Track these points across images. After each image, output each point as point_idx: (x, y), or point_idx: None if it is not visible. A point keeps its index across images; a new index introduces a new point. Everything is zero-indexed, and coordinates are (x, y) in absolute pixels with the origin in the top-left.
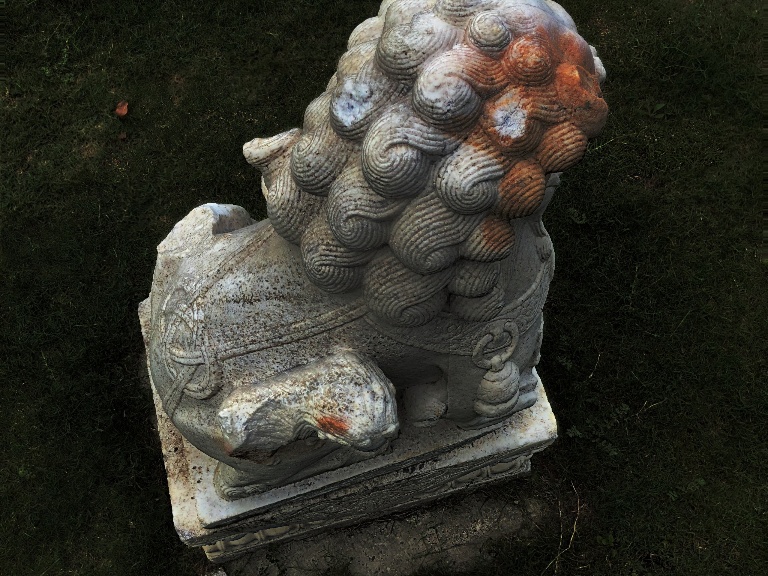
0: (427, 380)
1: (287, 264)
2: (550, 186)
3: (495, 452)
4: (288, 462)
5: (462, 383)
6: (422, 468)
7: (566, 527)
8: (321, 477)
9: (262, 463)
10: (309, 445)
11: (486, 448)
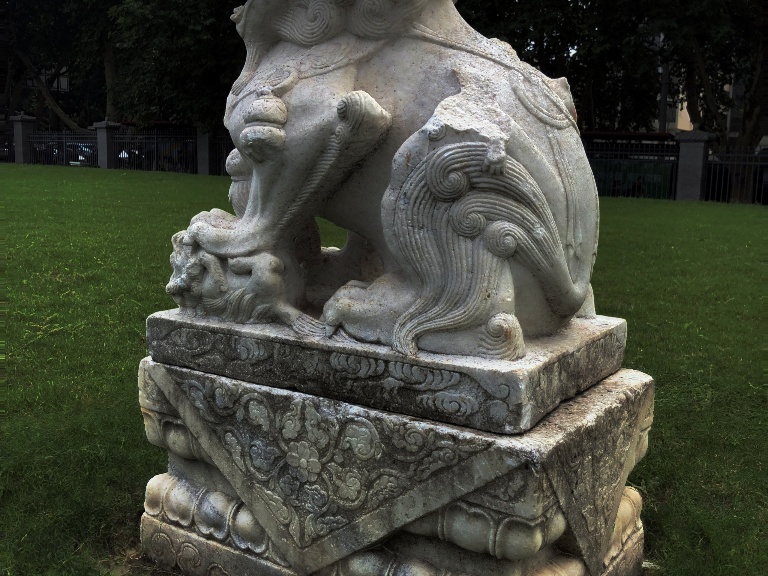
0: None
1: None
2: None
3: None
4: None
5: None
6: None
7: None
8: None
9: None
10: None
11: None
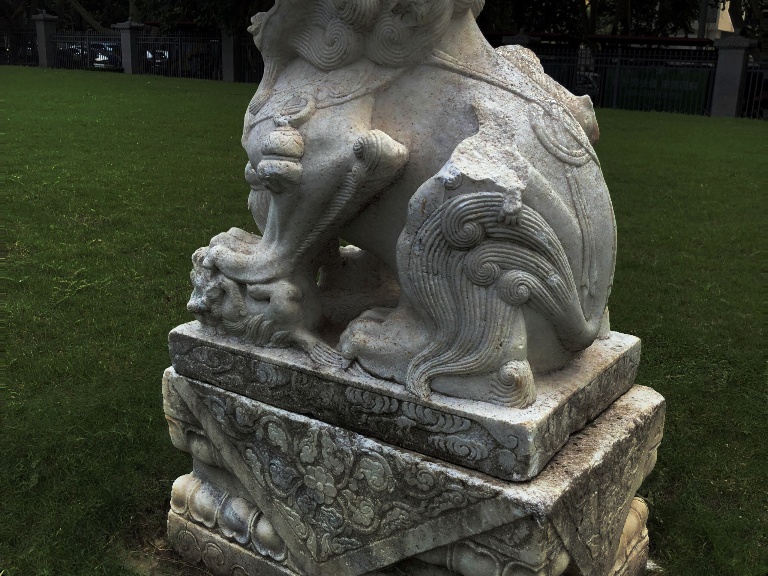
0: None
1: (479, 31)
2: None
3: None
4: None
5: None
6: None
7: None
8: None
9: None
10: None
11: None
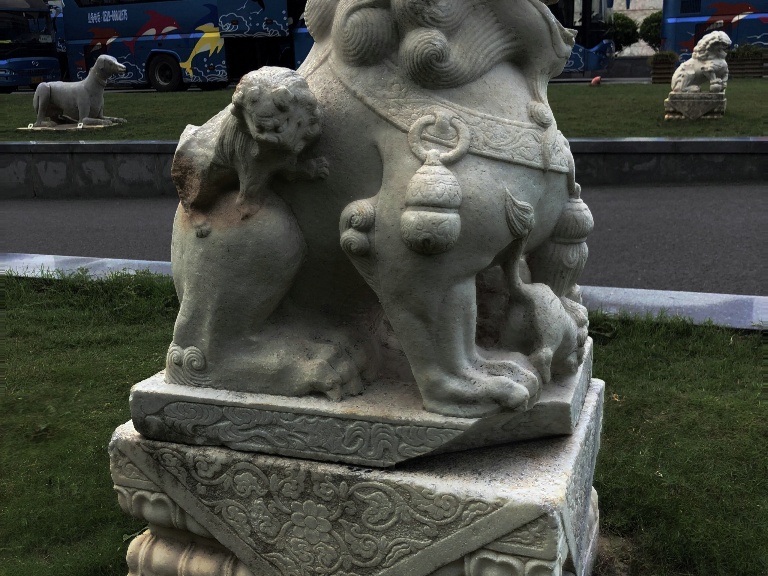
0: (371, 190)
1: None
2: (535, 7)
3: (463, 494)
4: (216, 238)
5: (395, 176)
6: (369, 472)
7: None
8: (257, 396)
9: (195, 218)
10: (237, 203)
11: (454, 484)
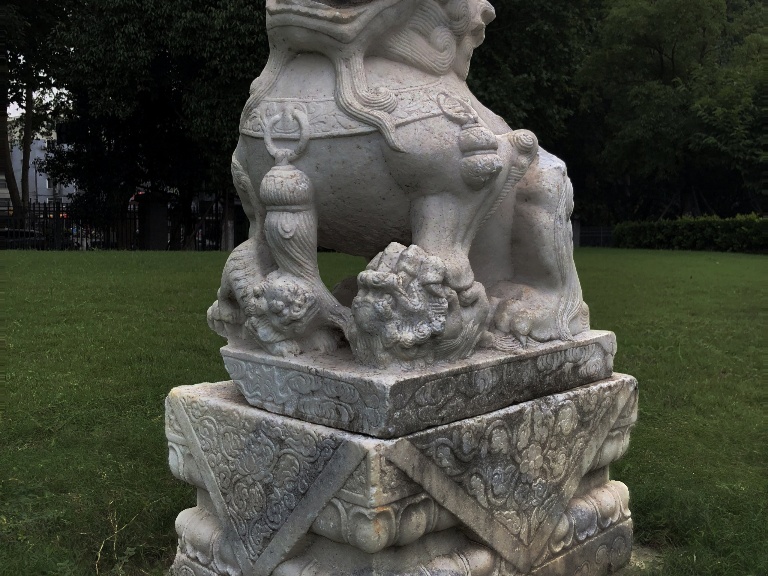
0: None
1: None
2: None
3: None
4: None
5: None
6: None
7: (108, 568)
8: None
9: None
10: None
11: None
